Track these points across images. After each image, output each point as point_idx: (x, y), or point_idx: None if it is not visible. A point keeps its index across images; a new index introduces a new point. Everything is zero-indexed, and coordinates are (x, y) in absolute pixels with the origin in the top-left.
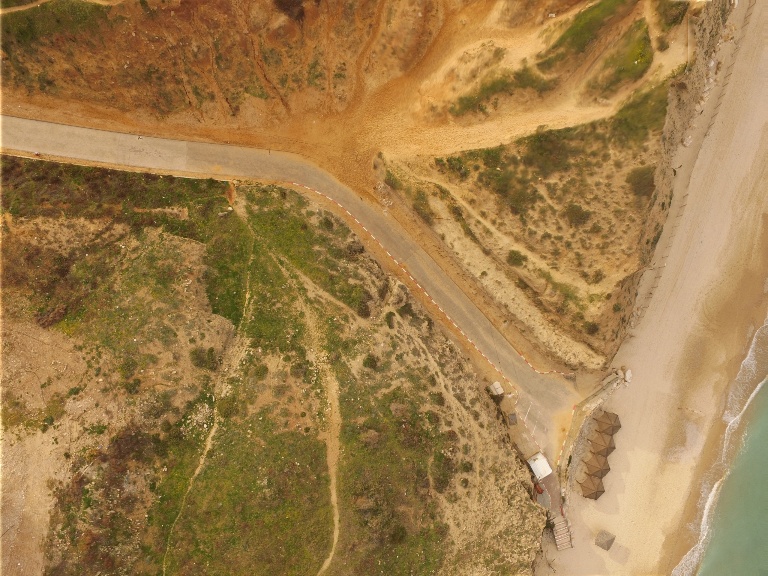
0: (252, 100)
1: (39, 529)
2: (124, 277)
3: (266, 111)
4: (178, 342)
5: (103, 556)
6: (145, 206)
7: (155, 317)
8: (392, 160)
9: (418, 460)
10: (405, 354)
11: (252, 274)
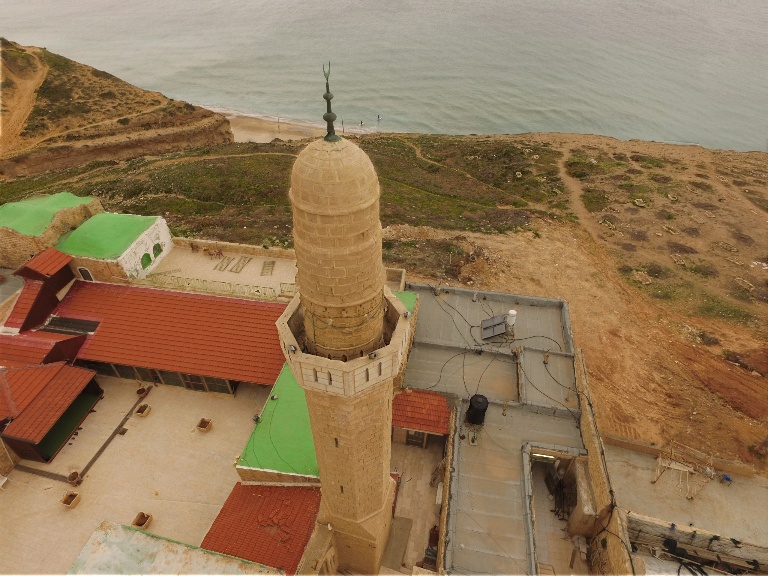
0: None
1: None
2: None
3: None
4: None
5: None
6: None
7: None
8: (1, 156)
9: None
10: None
11: None
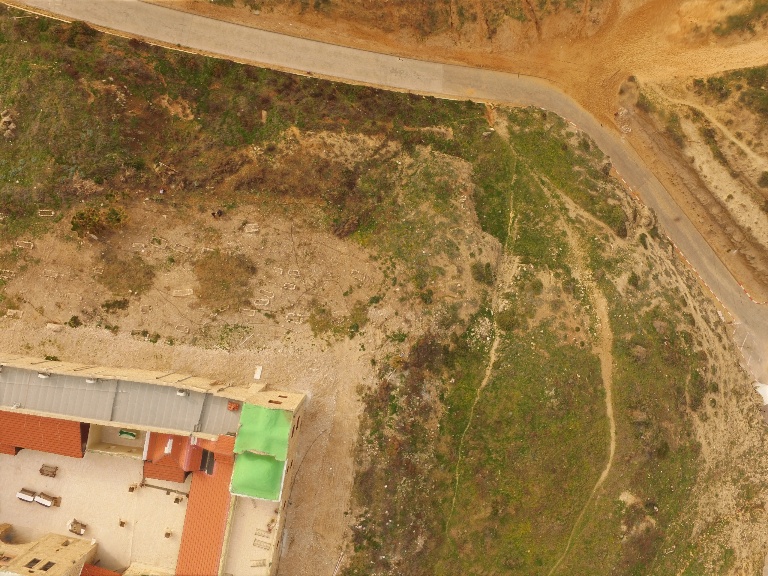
0: (510, 22)
1: (349, 434)
2: (405, 192)
3: (520, 34)
4: (460, 256)
5: (407, 462)
6: (414, 125)
7: (439, 231)
8: (646, 83)
9: (678, 377)
10: (660, 274)
11: (515, 194)
